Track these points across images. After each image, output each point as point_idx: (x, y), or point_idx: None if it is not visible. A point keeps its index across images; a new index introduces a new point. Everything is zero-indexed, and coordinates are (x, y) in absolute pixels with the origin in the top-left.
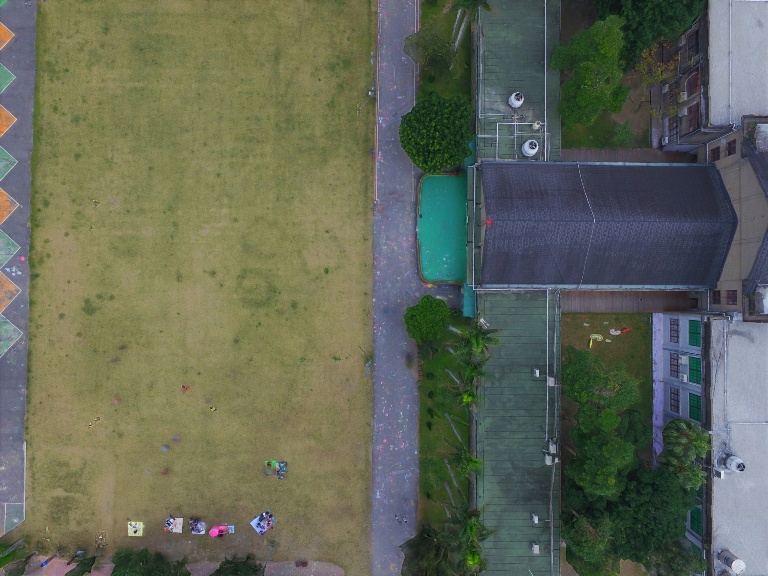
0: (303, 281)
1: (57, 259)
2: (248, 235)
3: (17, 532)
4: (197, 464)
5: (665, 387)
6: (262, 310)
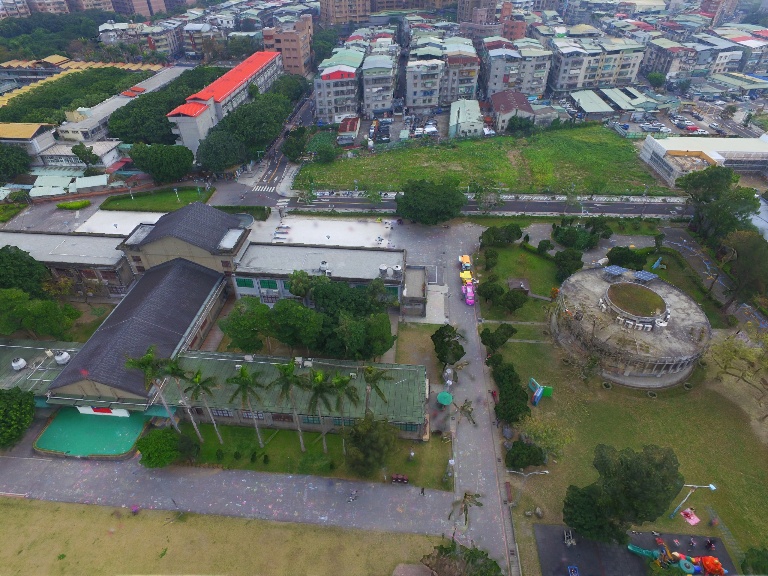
0: None
1: None
2: None
3: None
4: None
5: None
6: None
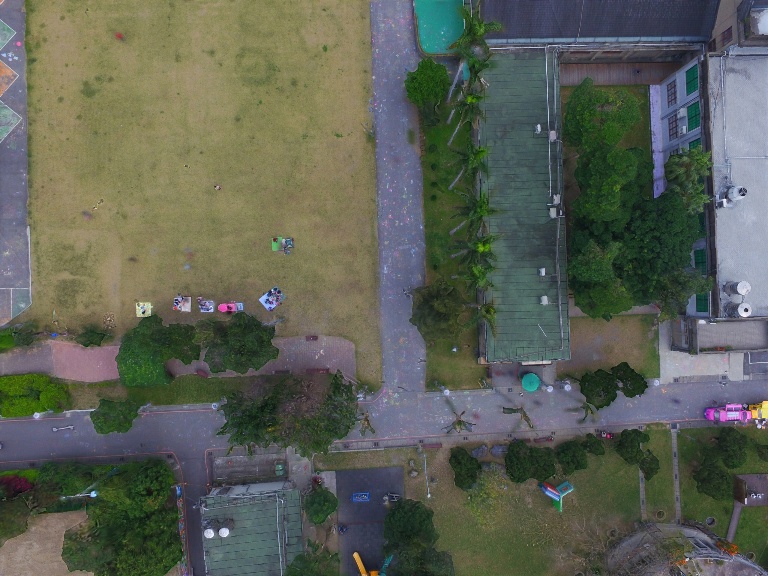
0: (302, 59)
1: (54, 43)
2: (245, 14)
3: (24, 317)
4: (203, 243)
5: (665, 155)
6: (262, 88)
